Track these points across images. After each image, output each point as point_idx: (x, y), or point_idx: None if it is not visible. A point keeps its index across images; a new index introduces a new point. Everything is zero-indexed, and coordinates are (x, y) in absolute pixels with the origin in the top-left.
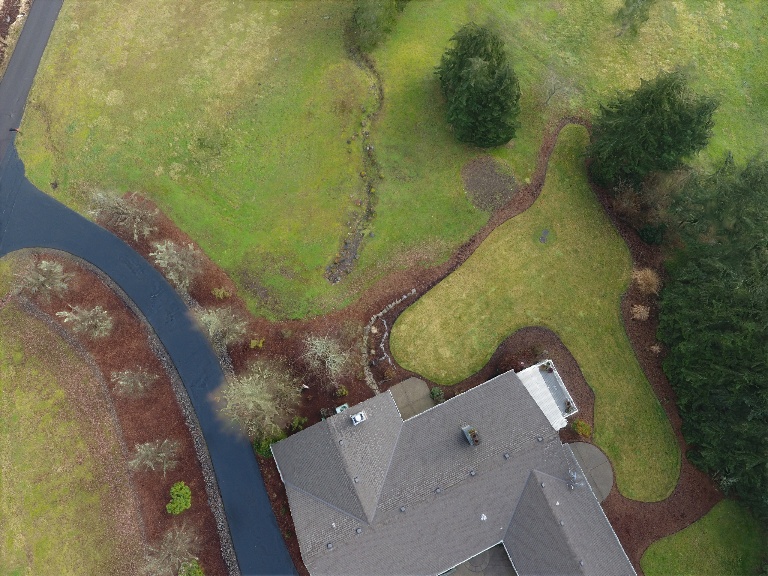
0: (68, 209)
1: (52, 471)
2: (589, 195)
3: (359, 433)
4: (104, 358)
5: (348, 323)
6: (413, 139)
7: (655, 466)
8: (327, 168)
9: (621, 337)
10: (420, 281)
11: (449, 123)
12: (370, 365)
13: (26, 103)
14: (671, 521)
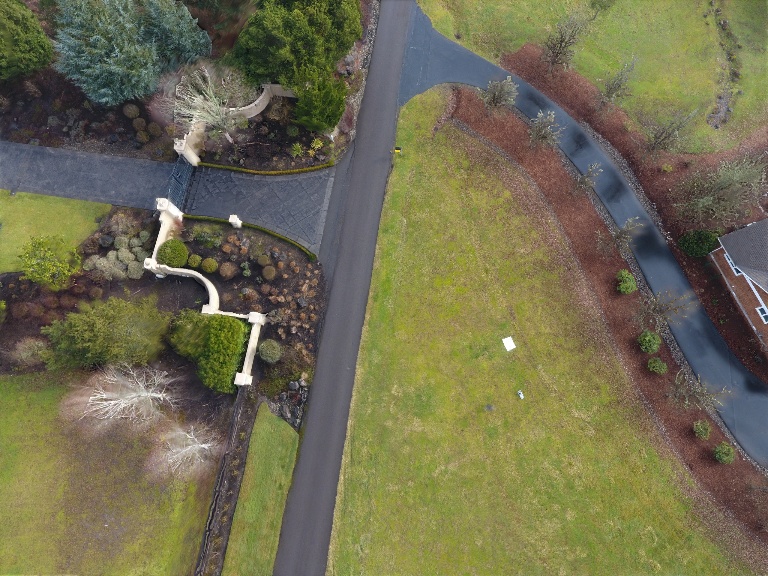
0: (476, 55)
1: (516, 252)
2: None
3: None
4: (534, 171)
5: None
6: (759, 18)
7: None
8: (691, 36)
9: None
10: None
11: None
12: None
13: None
14: None
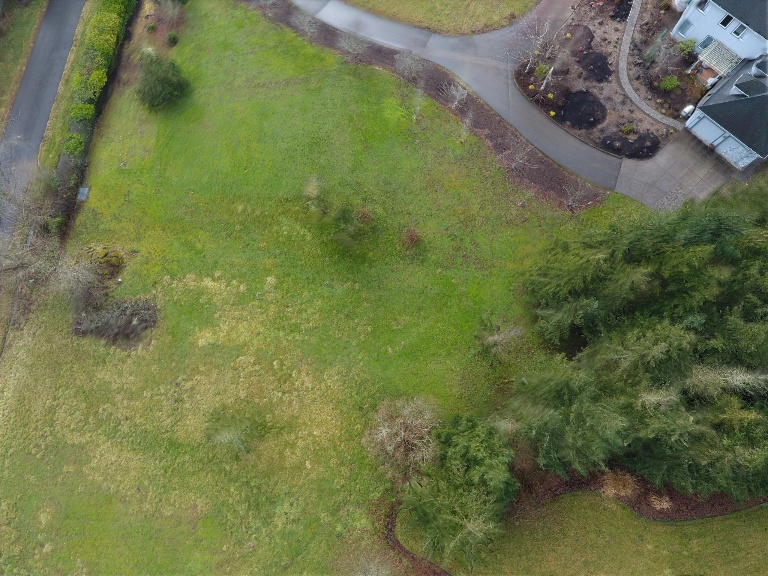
0: None
1: None
2: (502, 527)
3: None
4: None
5: None
6: None
7: None
8: None
9: (691, 529)
10: None
11: None
12: None
13: None
14: None
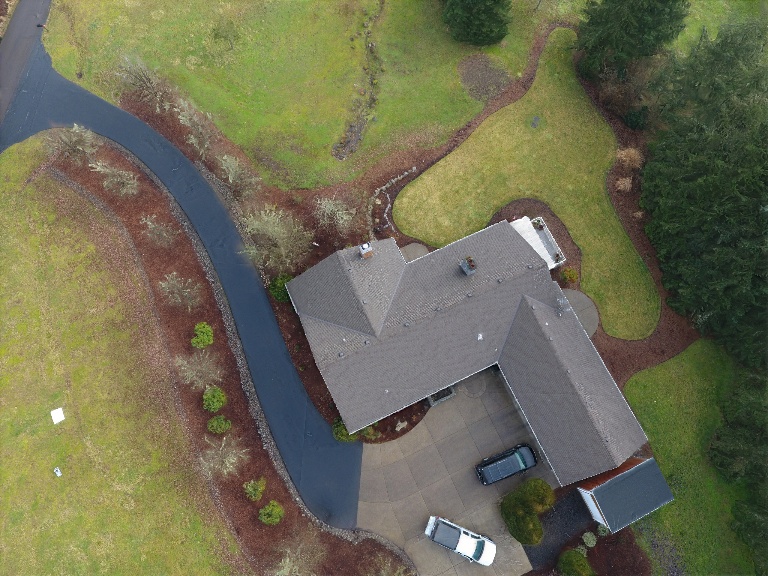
0: (93, 95)
1: (86, 312)
2: (577, 88)
3: (366, 266)
4: (130, 220)
5: (354, 190)
6: (412, 38)
7: (637, 310)
8: (332, 61)
9: (606, 206)
10: (420, 160)
11: (446, 25)
12: (375, 232)
13: (51, 5)
14: (652, 356)
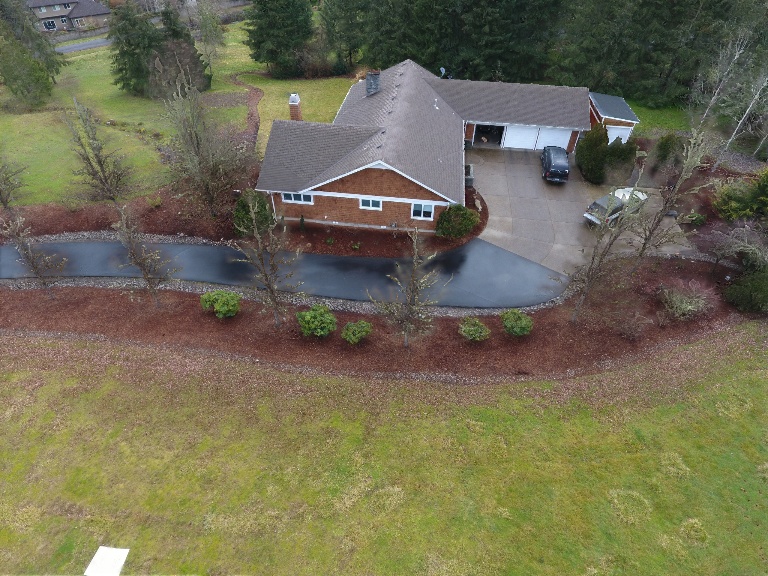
0: None
1: None
2: None
3: None
4: None
5: None
6: (141, 110)
7: None
8: None
9: None
10: (244, 138)
11: (158, 100)
12: None
13: None
14: None
